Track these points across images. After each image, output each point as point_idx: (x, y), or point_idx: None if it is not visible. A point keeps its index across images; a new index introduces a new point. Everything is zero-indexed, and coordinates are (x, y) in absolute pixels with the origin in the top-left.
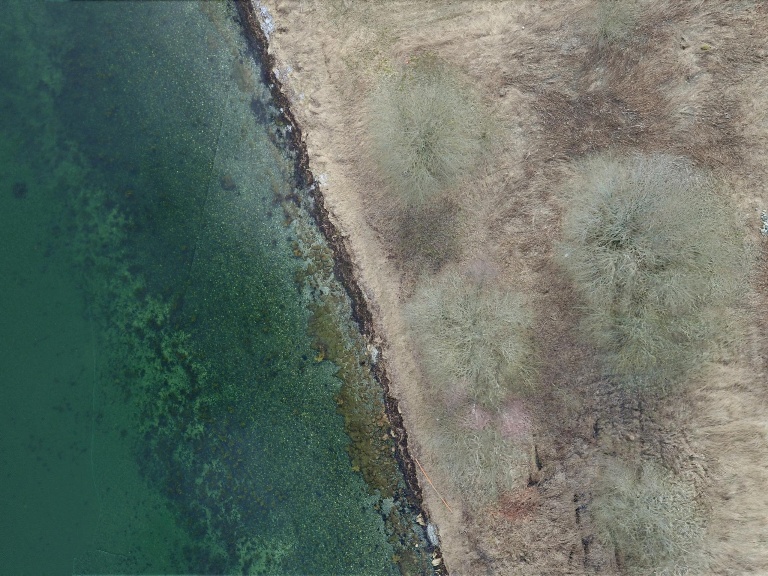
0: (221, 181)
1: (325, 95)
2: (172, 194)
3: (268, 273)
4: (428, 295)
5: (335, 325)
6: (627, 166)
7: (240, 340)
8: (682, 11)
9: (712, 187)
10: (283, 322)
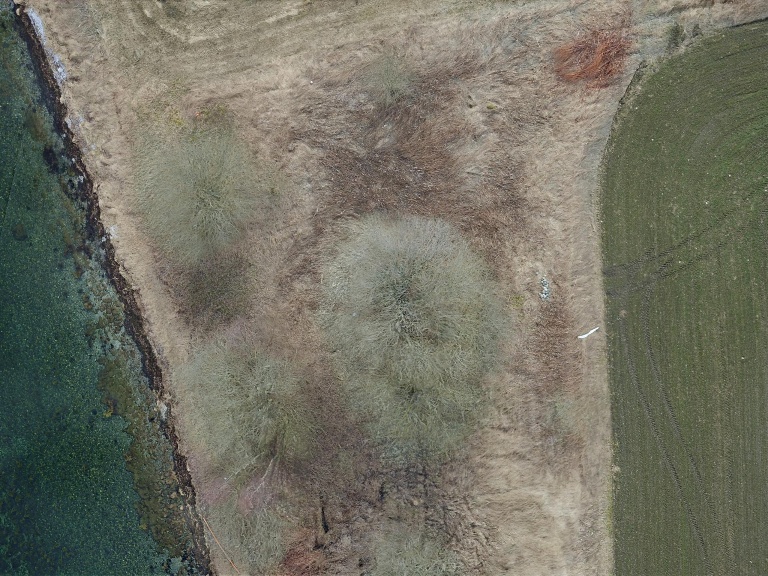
0: (13, 231)
1: (116, 146)
2: None
3: (59, 325)
4: (217, 352)
5: (125, 380)
6: (415, 225)
7: (30, 393)
8: (468, 69)
9: (495, 249)
10: (73, 375)
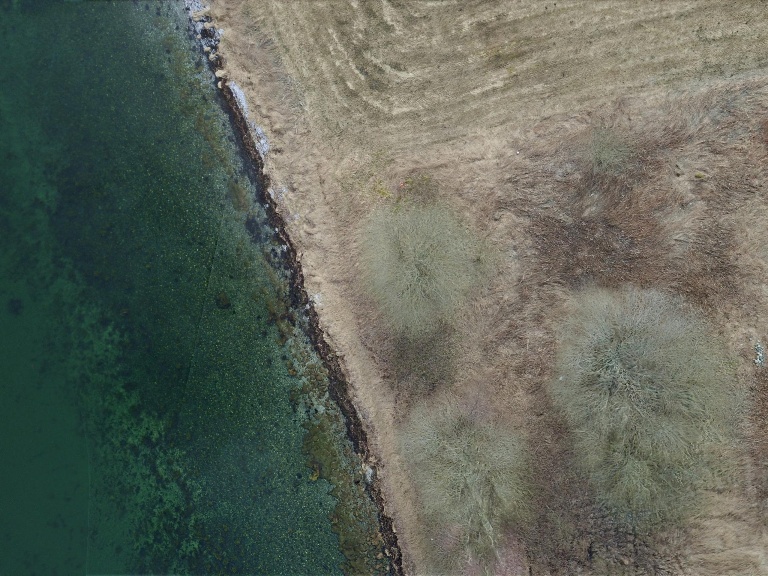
0: (216, 300)
1: (320, 216)
2: (167, 312)
3: (263, 391)
4: (423, 416)
5: (330, 444)
6: (621, 291)
7: (235, 458)
8: (676, 139)
9: (706, 315)
10: (278, 440)
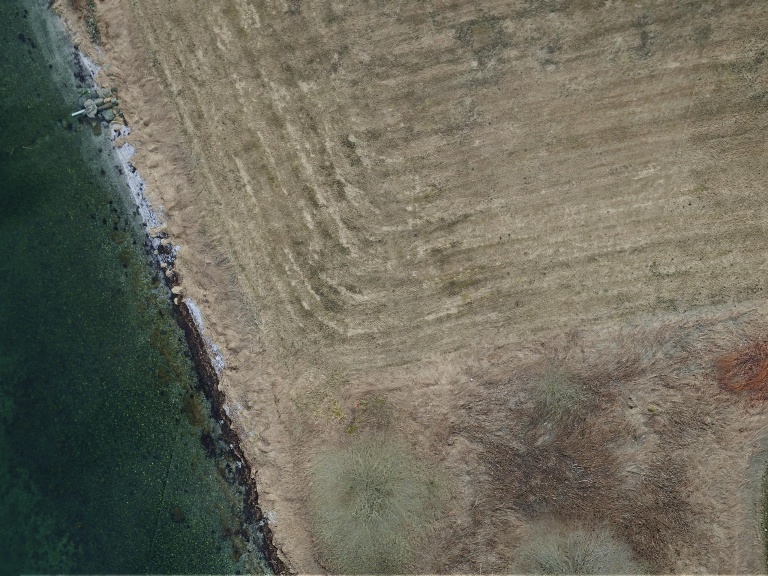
0: (171, 513)
1: (274, 434)
2: (122, 525)
3: None
4: None
5: None
6: (574, 519)
7: None
8: (629, 372)
9: (658, 550)
10: None
